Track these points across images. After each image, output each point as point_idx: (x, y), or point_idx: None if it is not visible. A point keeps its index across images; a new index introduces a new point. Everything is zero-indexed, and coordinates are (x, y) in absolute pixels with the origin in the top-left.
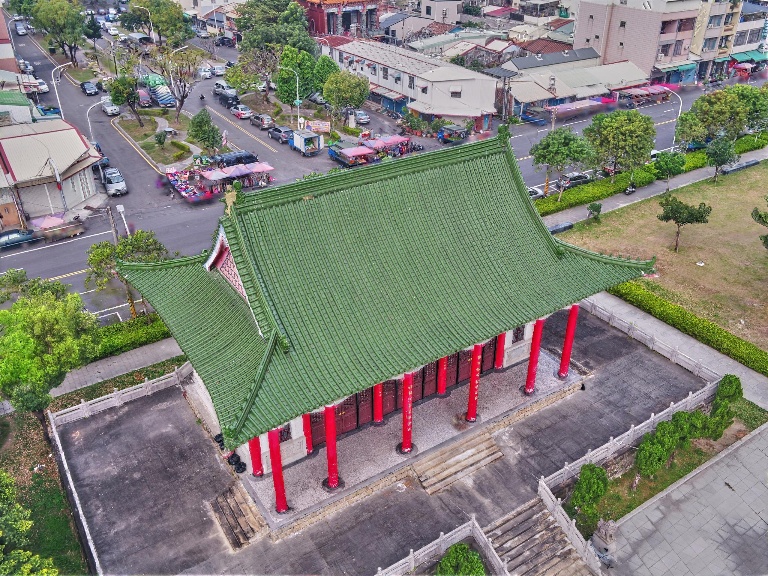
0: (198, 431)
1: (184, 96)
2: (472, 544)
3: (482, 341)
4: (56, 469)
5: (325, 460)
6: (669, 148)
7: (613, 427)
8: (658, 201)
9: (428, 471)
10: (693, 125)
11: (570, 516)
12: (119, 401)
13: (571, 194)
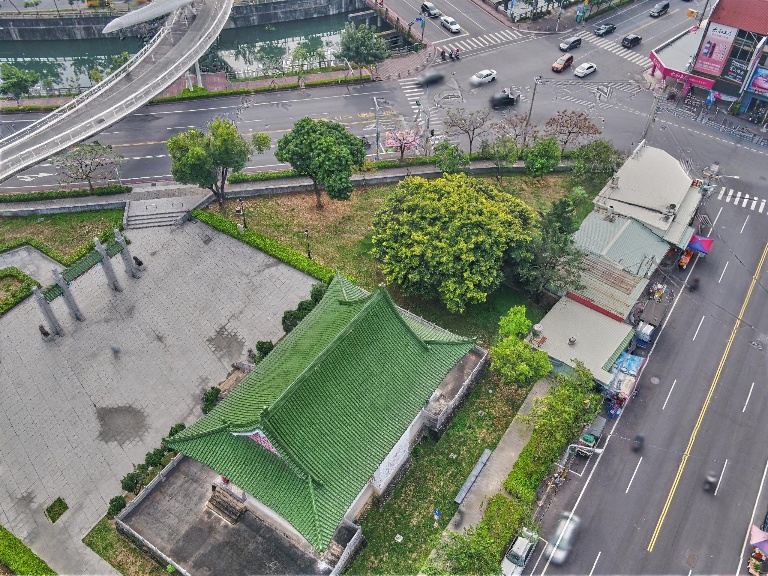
0: None
1: None
2: None
3: None
4: None
5: None
6: None
7: None
8: None
9: None
10: None
11: None
12: None
13: None
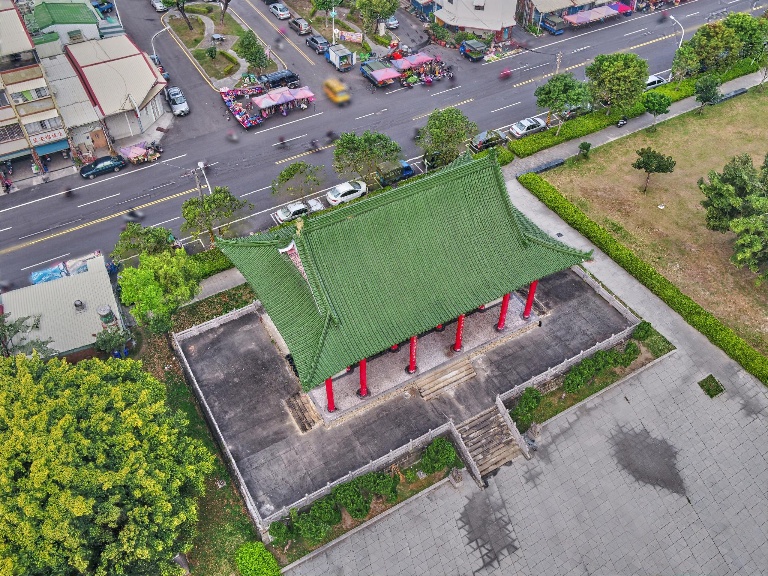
0: (273, 349)
1: (228, 0)
2: (449, 435)
3: None
4: (180, 369)
5: (358, 376)
6: (670, 69)
7: (555, 357)
8: (644, 136)
9: (425, 385)
10: (689, 59)
11: (516, 416)
12: (217, 324)
13: (569, 127)
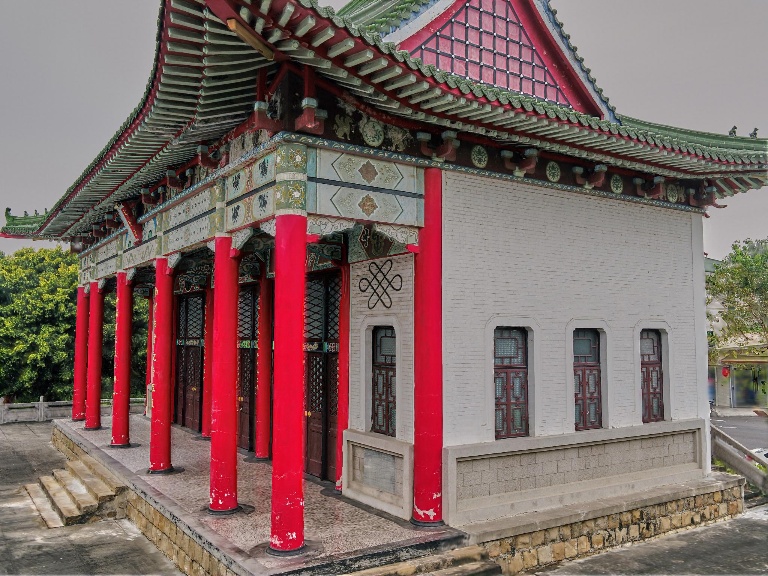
0: None
1: None
2: None
3: (162, 254)
4: None
5: (144, 426)
6: None
7: None
8: None
9: None
10: None
11: None
12: None
13: None
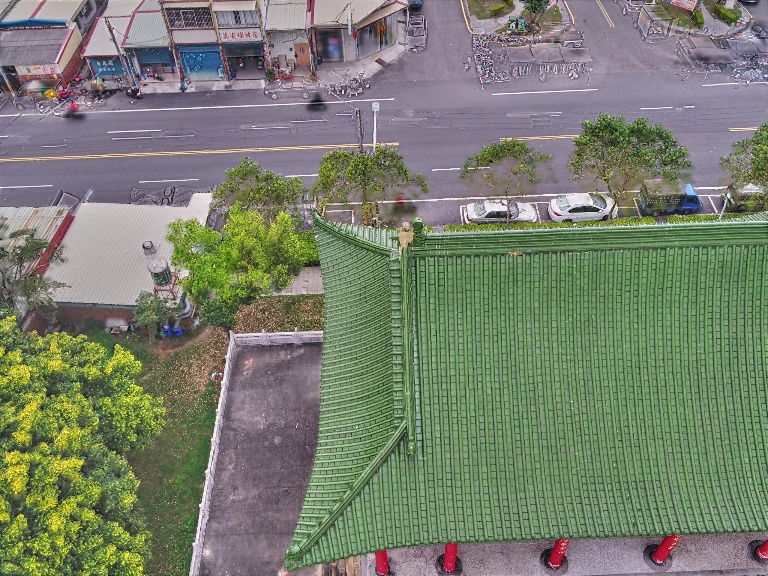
0: None
1: None
2: None
3: None
4: None
5: None
6: None
7: None
8: None
9: None
10: None
11: None
12: (298, 340)
13: None
